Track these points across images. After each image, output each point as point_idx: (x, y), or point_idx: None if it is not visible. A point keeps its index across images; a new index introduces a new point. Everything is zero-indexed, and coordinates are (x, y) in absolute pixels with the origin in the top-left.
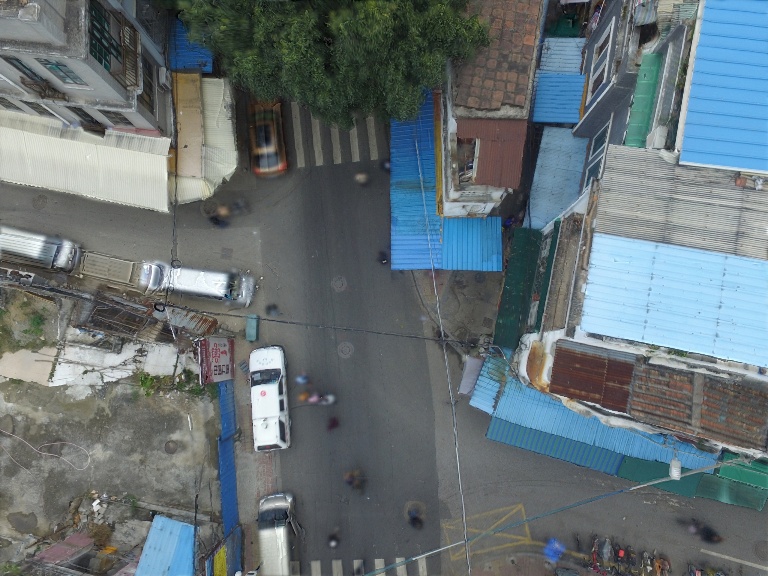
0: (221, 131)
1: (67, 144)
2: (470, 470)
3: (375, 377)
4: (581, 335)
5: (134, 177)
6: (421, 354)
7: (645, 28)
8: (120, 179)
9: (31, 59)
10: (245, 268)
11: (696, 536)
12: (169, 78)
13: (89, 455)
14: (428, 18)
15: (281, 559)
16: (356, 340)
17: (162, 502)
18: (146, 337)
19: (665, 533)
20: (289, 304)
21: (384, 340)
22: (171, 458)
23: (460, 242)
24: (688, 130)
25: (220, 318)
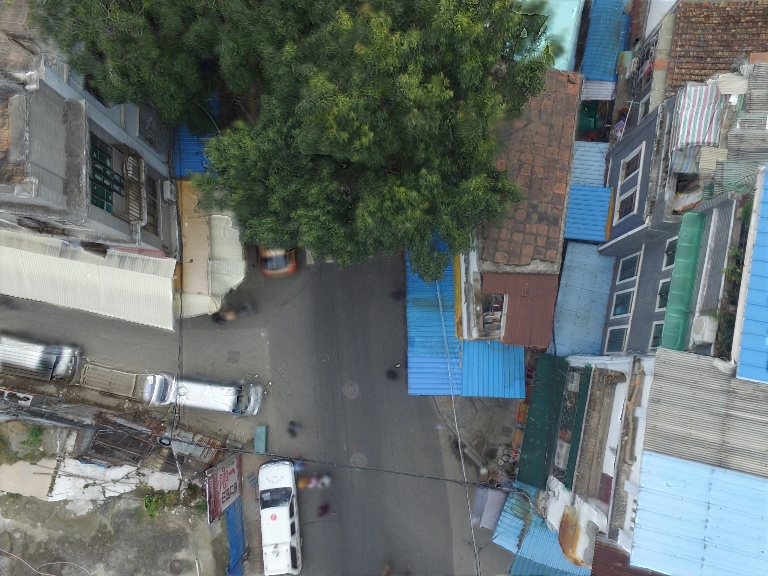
0: (228, 240)
1: (67, 263)
2: None
3: (390, 491)
4: (627, 547)
5: (137, 296)
6: (437, 466)
7: (683, 175)
8: (122, 298)
9: None
10: (253, 373)
11: None
12: (174, 191)
13: (91, 575)
14: (458, 195)
15: None
16: (369, 451)
17: None
18: (150, 466)
19: None
20: (299, 412)
21: (399, 451)
22: None
23: (481, 366)
24: (746, 341)
25: (227, 427)
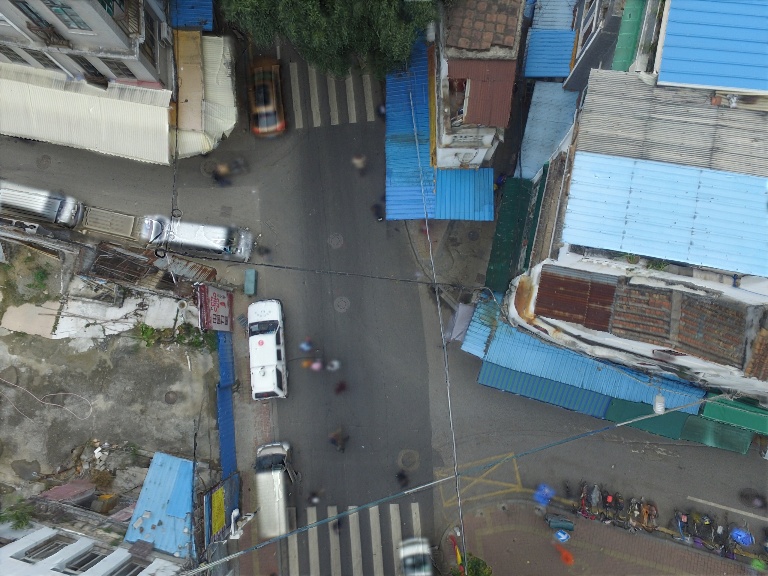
0: (221, 88)
1: (71, 97)
2: (463, 420)
3: (370, 331)
4: (564, 254)
5: (136, 129)
6: (415, 309)
7: None
8: (122, 132)
9: (37, 0)
10: (244, 225)
11: (683, 484)
12: (170, 34)
13: (91, 405)
14: None
15: (278, 505)
16: (352, 295)
17: (162, 450)
18: (147, 285)
19: (652, 481)
20: (287, 260)
21: (379, 295)
22: (171, 408)
23: (453, 193)
24: (666, 52)
25: (219, 274)
